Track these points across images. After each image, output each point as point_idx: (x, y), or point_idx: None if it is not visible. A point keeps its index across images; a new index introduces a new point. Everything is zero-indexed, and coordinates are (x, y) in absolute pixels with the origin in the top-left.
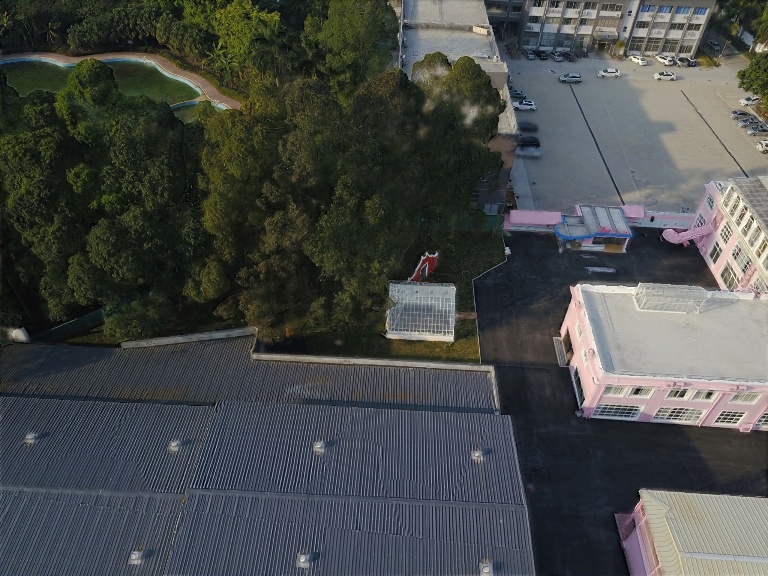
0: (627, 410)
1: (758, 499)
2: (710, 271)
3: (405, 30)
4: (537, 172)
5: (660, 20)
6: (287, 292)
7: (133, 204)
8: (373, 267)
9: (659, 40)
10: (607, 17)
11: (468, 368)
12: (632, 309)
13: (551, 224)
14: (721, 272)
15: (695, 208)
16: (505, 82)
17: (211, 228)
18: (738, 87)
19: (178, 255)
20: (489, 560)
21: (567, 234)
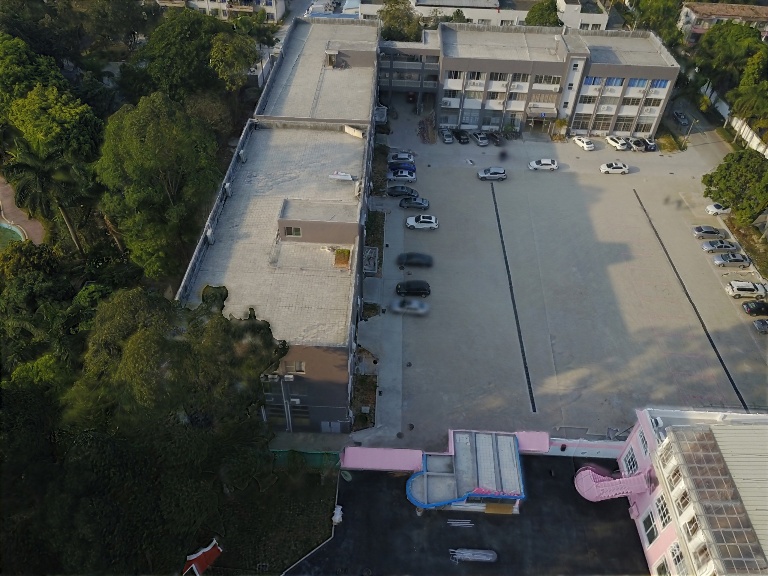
0: None
1: None
2: (642, 553)
3: (254, 131)
4: (418, 342)
5: (609, 94)
6: None
7: None
8: None
9: (610, 117)
10: (542, 91)
11: None
12: None
13: (406, 470)
14: (657, 565)
15: (633, 407)
16: (356, 234)
17: None
18: (703, 196)
19: None
20: None
21: (423, 498)
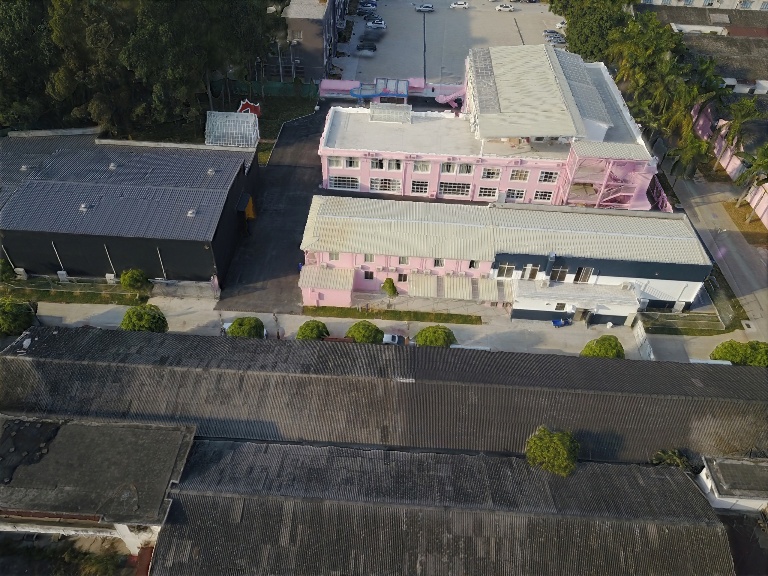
0: (351, 182)
1: (386, 200)
2: None
3: None
4: (366, 66)
5: None
6: (122, 101)
7: (6, 24)
8: (168, 73)
9: None
10: None
11: (240, 150)
12: (365, 121)
13: None
14: None
15: None
16: None
17: (55, 39)
18: (548, 11)
19: (40, 65)
20: (195, 210)
21: (358, 93)
